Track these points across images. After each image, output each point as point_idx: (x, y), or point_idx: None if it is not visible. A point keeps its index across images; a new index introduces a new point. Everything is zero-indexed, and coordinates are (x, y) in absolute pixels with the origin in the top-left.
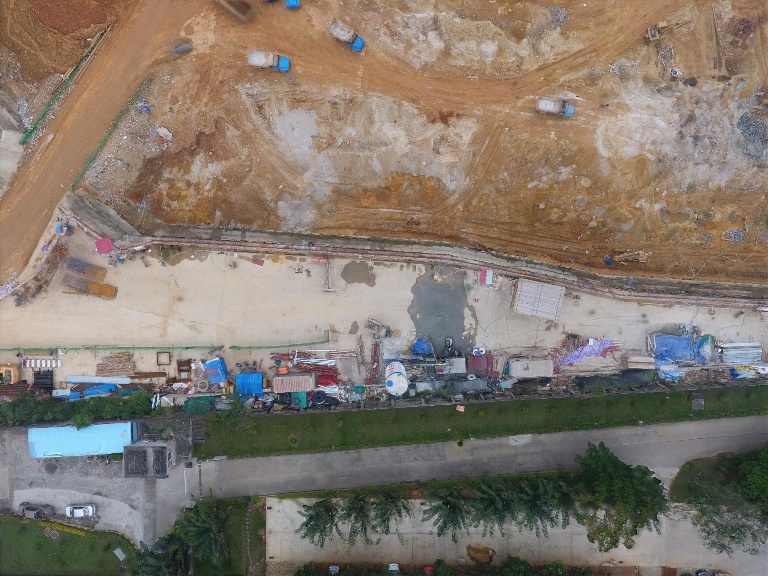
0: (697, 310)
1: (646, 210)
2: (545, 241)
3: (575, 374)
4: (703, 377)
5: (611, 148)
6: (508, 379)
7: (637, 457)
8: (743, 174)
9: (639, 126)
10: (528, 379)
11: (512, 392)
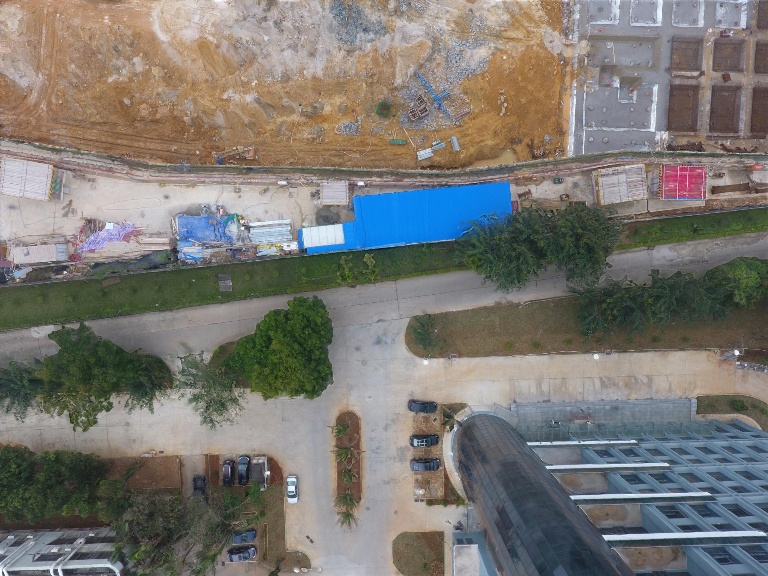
0: (222, 189)
1: (235, 101)
2: (152, 142)
3: (94, 260)
4: (229, 257)
5: (168, 31)
6: (22, 269)
7: (168, 344)
8: (334, 60)
9: (197, 7)
10: (43, 267)
11: (23, 281)
